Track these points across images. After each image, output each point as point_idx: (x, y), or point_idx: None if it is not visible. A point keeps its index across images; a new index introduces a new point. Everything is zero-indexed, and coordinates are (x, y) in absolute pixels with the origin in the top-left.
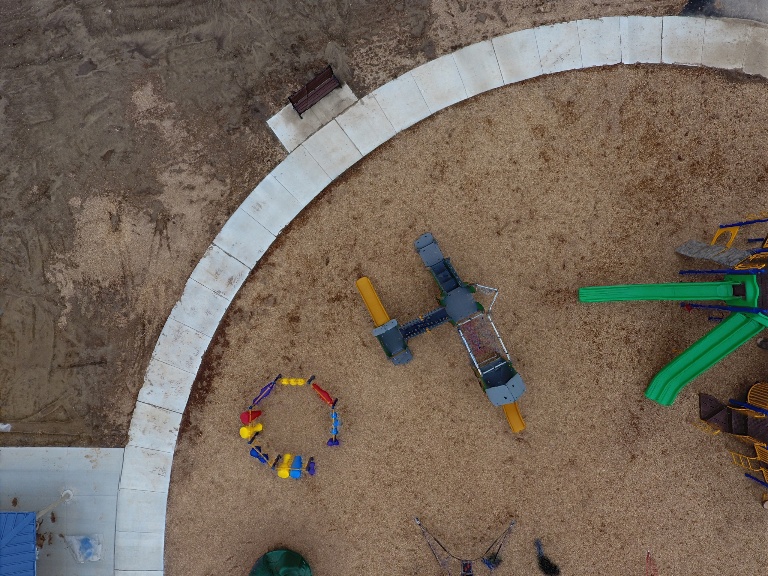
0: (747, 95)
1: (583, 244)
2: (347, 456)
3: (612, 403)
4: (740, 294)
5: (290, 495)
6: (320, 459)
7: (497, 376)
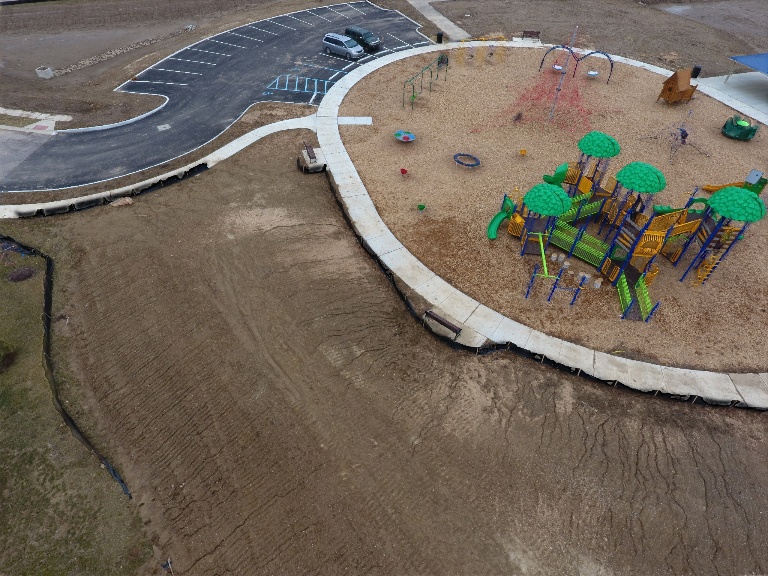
0: (767, 357)
1: (762, 258)
2: (759, 168)
3: (673, 205)
4: (708, 219)
5: (764, 154)
6: (767, 165)
7: (760, 183)
